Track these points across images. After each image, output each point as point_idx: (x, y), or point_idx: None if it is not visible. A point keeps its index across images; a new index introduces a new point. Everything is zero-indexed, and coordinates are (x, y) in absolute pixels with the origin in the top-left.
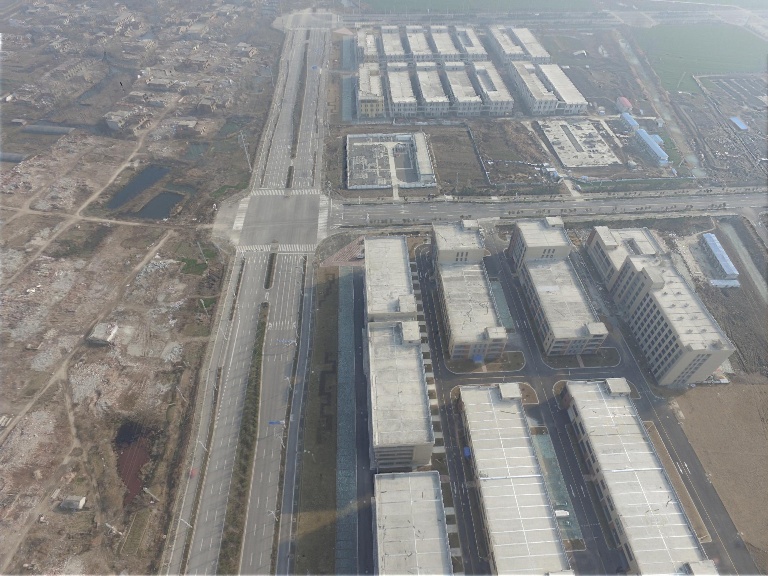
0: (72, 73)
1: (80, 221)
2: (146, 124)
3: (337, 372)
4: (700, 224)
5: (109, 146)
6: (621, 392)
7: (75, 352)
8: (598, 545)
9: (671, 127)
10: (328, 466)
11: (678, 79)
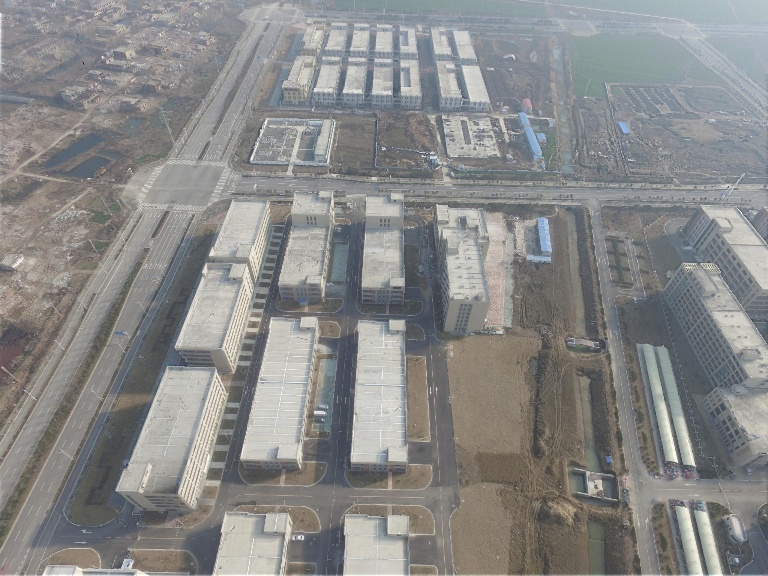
0: (46, 51)
1: (18, 176)
2: (96, 99)
3: (186, 303)
4: (543, 211)
5: (60, 116)
6: (397, 330)
7: None
8: (340, 437)
9: (562, 128)
10: (154, 368)
11: (590, 85)
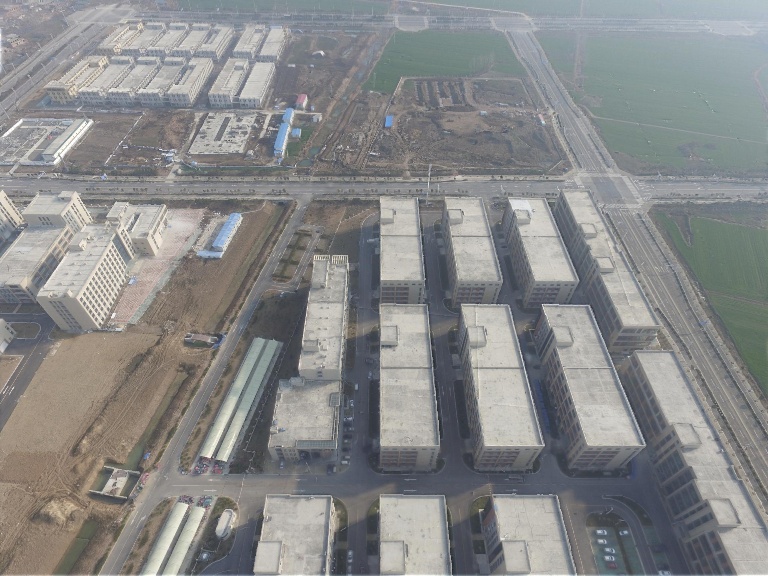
0: None
1: None
2: None
3: None
4: (248, 206)
5: None
6: None
7: None
8: None
9: (328, 123)
10: None
11: (384, 80)
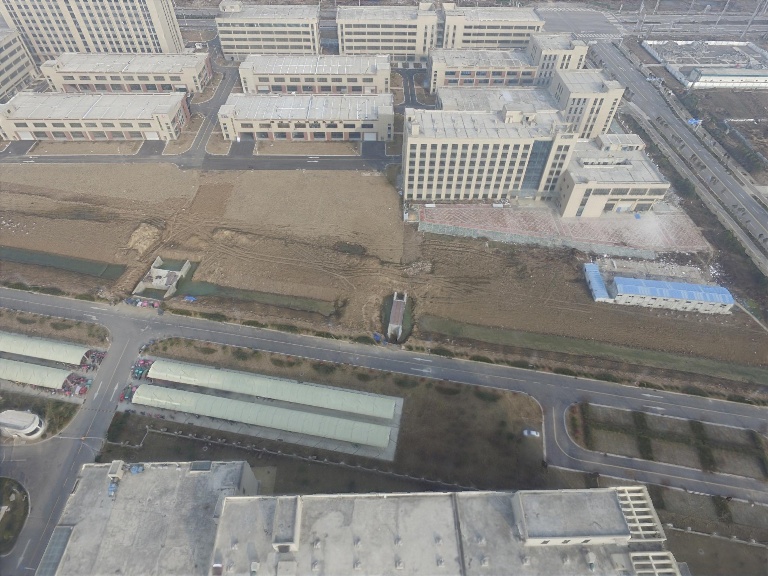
0: None
1: None
2: None
3: None
4: None
5: None
6: None
7: None
8: None
9: None
10: None
11: None
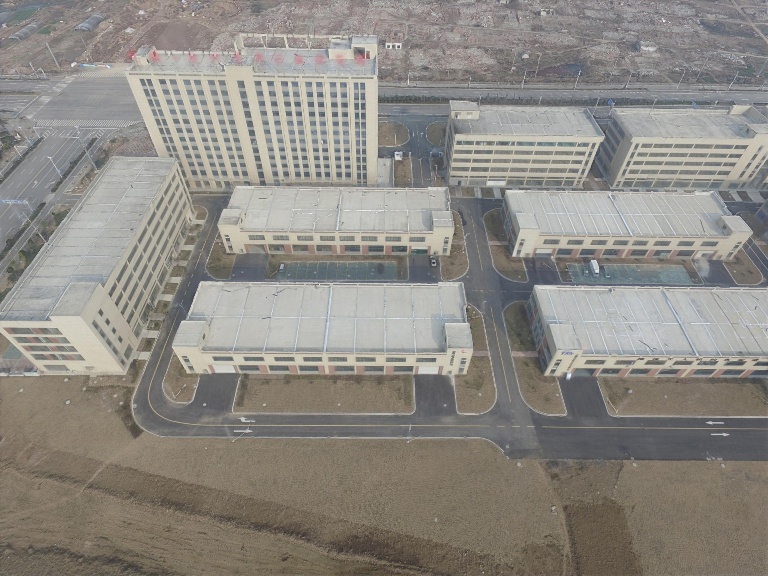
0: None
1: (749, 25)
2: None
3: None
4: None
5: None
6: None
7: (624, 42)
8: None
9: None
10: None
11: None
